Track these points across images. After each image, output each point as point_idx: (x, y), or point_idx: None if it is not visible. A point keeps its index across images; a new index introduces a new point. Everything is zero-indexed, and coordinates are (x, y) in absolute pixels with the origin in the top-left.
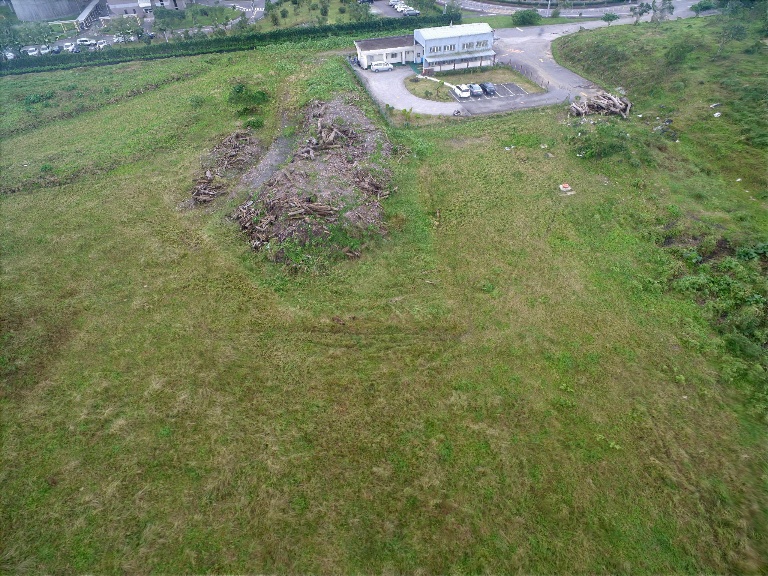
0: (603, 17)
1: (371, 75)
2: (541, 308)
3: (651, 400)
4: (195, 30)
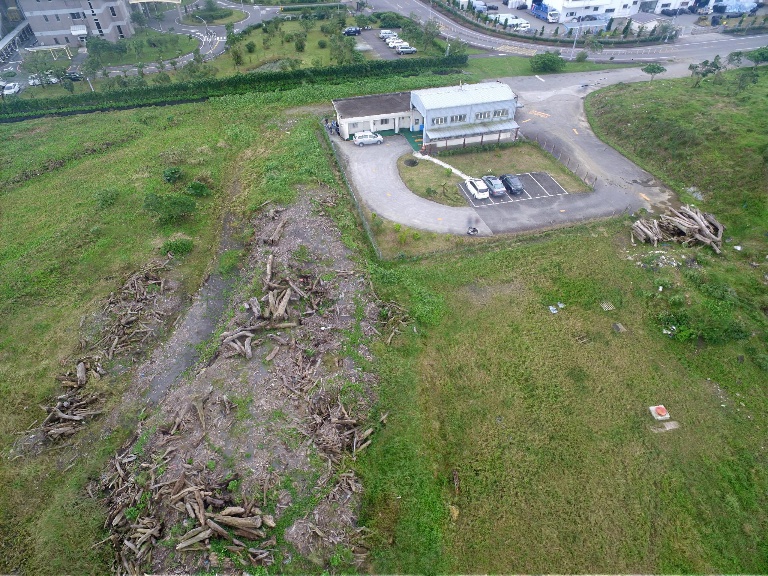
0: (645, 68)
1: (353, 151)
2: None
3: None
4: (137, 68)
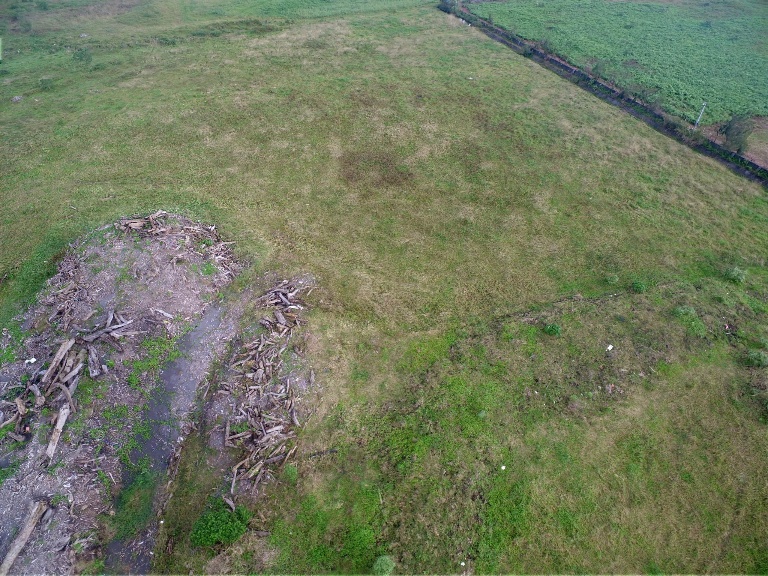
0: None
1: None
2: (6, 200)
3: (3, 163)
4: None
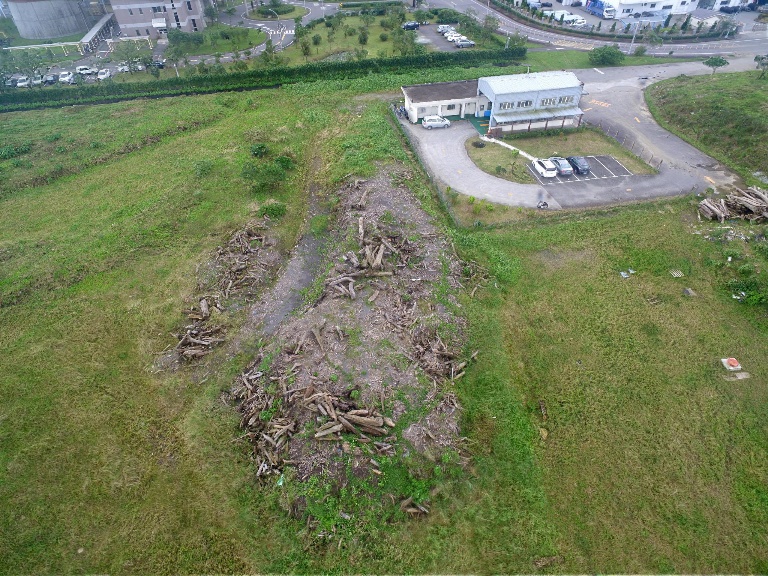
0: (707, 61)
1: (422, 133)
2: None
3: None
4: (213, 58)
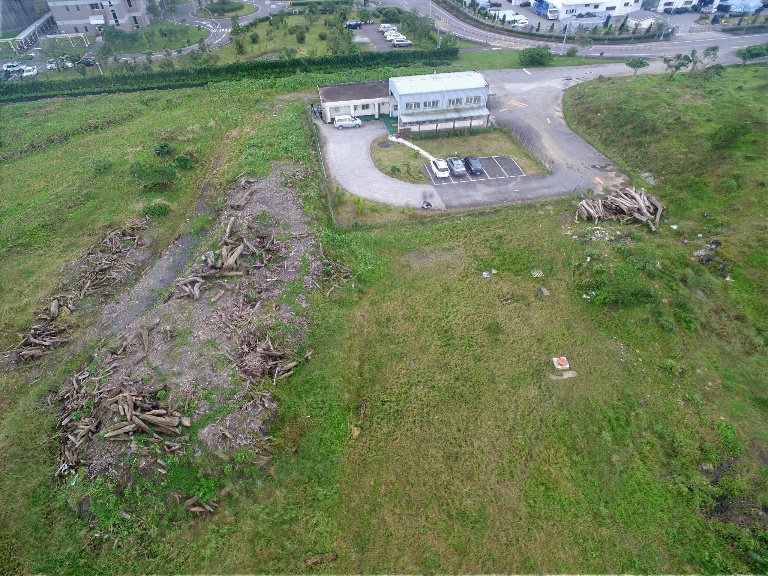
0: (629, 62)
1: (332, 133)
2: None
3: None
4: None
